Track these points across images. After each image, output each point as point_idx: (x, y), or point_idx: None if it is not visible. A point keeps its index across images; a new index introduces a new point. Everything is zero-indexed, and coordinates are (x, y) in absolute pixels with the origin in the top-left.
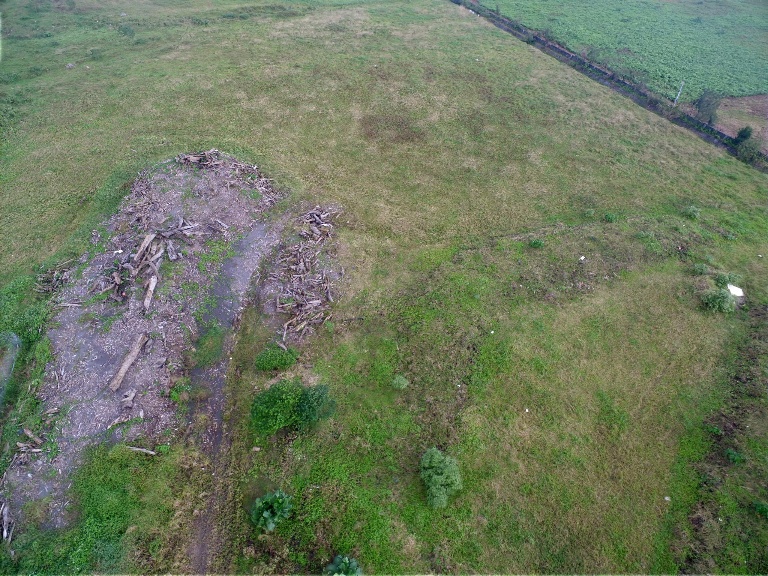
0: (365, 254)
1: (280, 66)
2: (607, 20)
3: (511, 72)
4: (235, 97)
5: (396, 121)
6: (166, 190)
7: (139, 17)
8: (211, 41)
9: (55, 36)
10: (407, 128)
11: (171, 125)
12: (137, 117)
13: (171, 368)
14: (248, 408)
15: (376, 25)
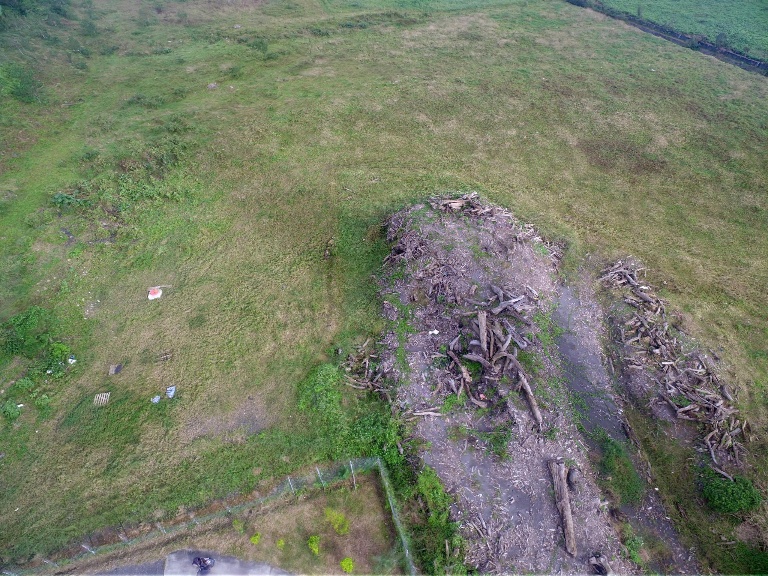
0: (719, 328)
1: (440, 82)
2: (763, 21)
3: (703, 84)
4: (417, 120)
5: (619, 147)
6: (451, 247)
7: (255, 29)
8: (345, 54)
9: (175, 52)
10: (639, 155)
11: (368, 156)
12: (323, 147)
13: (604, 510)
14: (735, 573)
15: (511, 32)
